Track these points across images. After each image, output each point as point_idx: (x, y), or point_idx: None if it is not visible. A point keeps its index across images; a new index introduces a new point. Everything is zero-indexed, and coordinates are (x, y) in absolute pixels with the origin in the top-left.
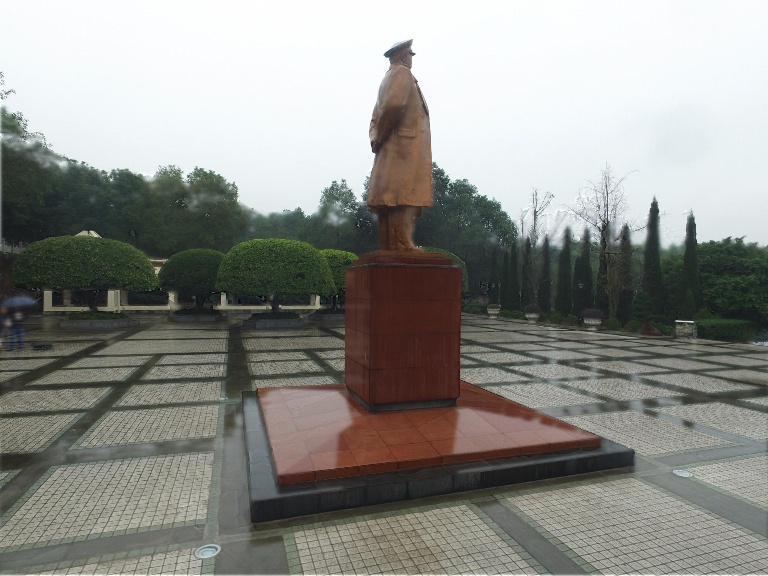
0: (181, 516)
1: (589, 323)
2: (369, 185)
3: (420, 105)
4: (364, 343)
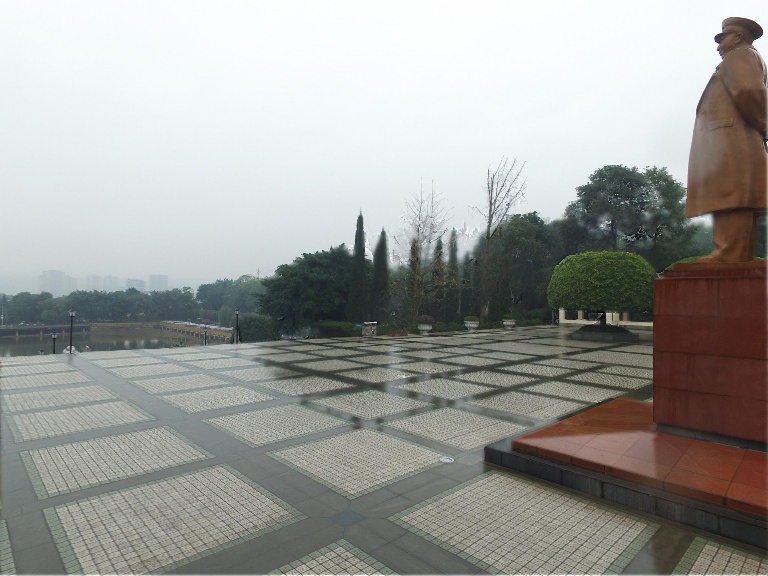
0: None
1: None
2: None
3: None
4: None
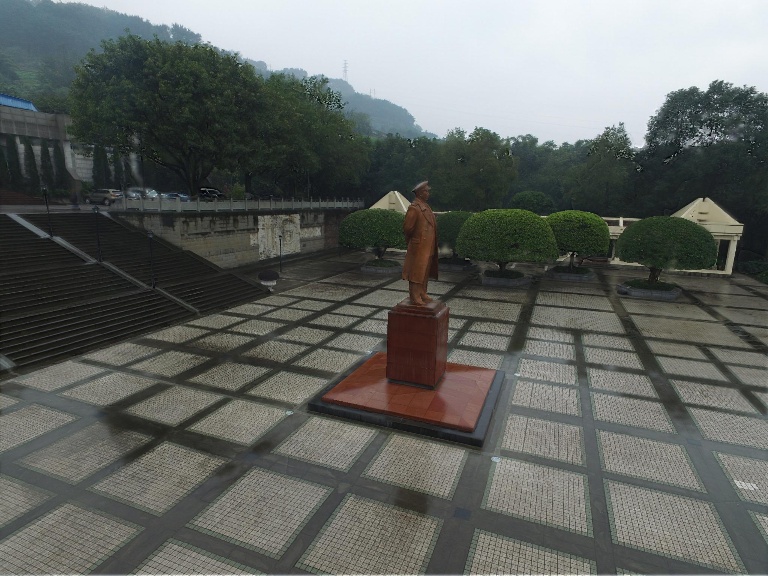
0: None
1: None
2: None
3: (425, 224)
4: None
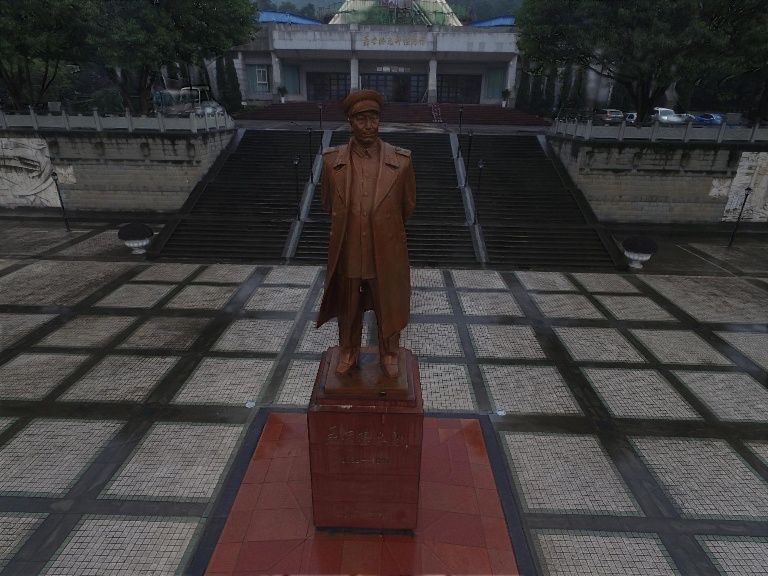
0: (284, 397)
1: None
2: None
3: (335, 200)
4: None
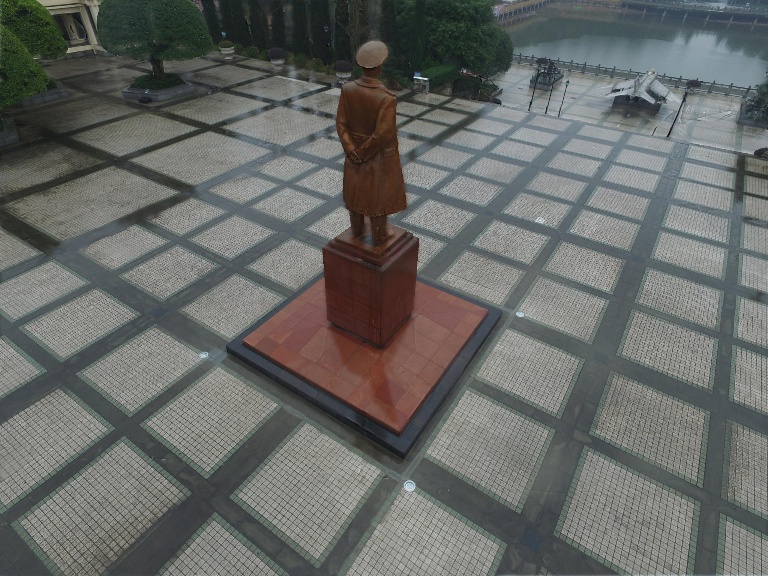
0: (369, 477)
1: (342, 77)
2: (349, 190)
3: None
4: (370, 313)
